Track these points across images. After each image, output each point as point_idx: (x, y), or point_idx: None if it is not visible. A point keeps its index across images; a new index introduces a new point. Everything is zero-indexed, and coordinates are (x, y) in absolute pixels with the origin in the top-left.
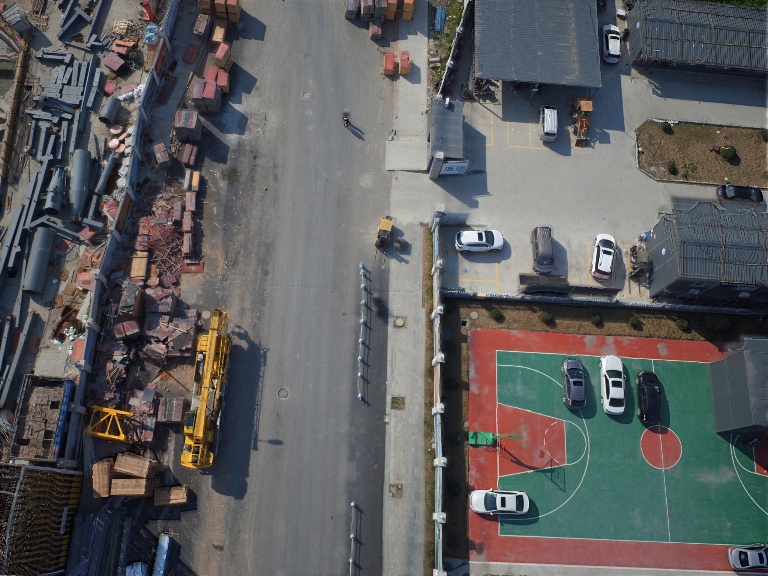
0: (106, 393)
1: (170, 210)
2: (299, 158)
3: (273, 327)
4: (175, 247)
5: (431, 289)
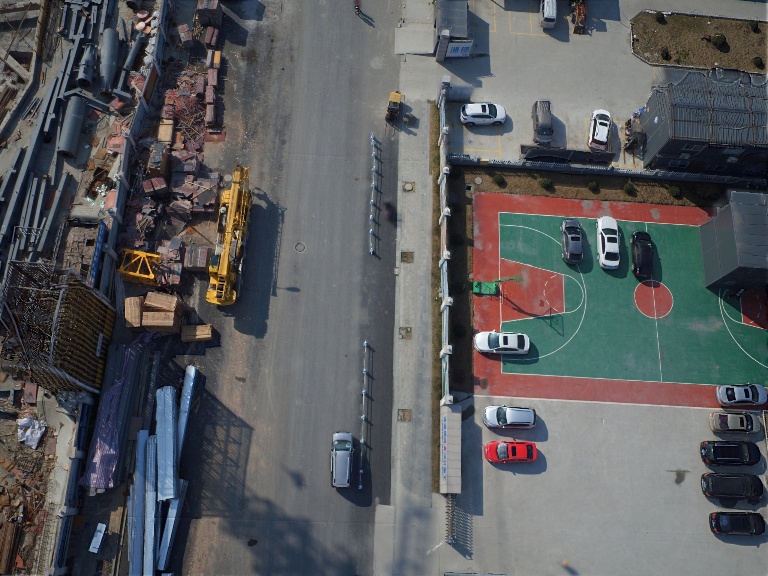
0: (136, 241)
1: (194, 84)
2: (313, 42)
3: (290, 189)
4: (198, 117)
5: (438, 158)
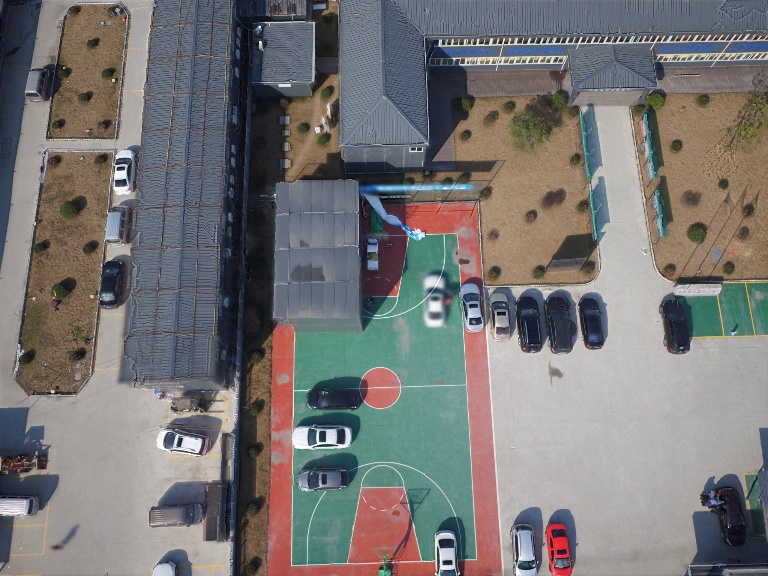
0: None
1: None
2: None
3: None
4: None
5: None
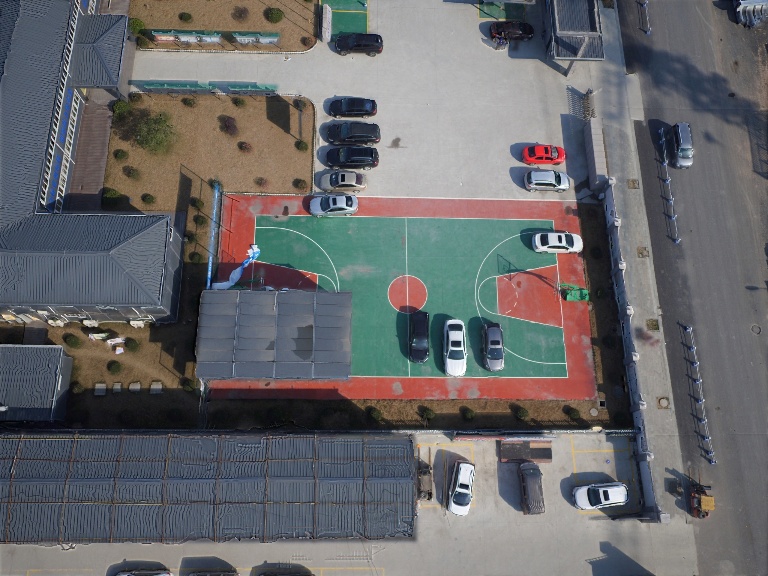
0: None
1: None
2: None
3: None
4: None
5: None
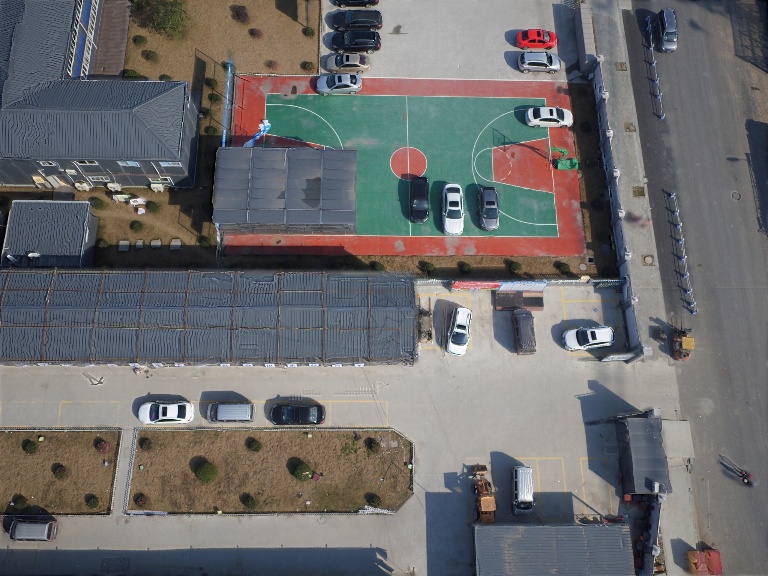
0: None
1: None
2: None
3: (760, 250)
4: None
5: None
